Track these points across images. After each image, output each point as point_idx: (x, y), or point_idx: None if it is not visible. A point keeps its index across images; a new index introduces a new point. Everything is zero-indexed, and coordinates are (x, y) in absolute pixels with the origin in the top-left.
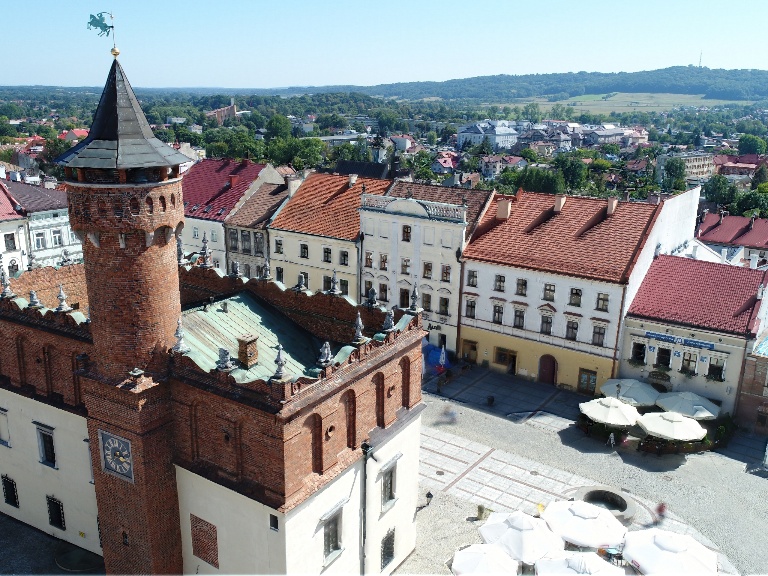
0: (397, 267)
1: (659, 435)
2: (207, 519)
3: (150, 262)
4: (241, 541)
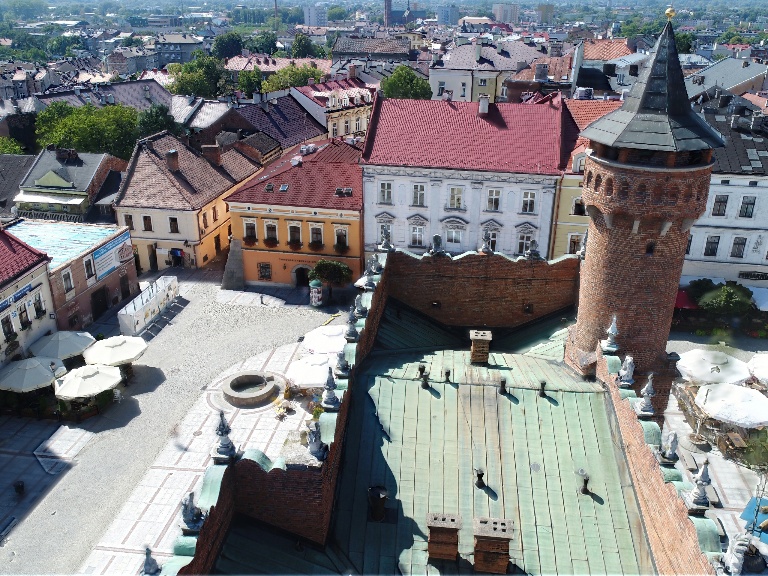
0: None
1: (141, 353)
2: None
3: None
4: None
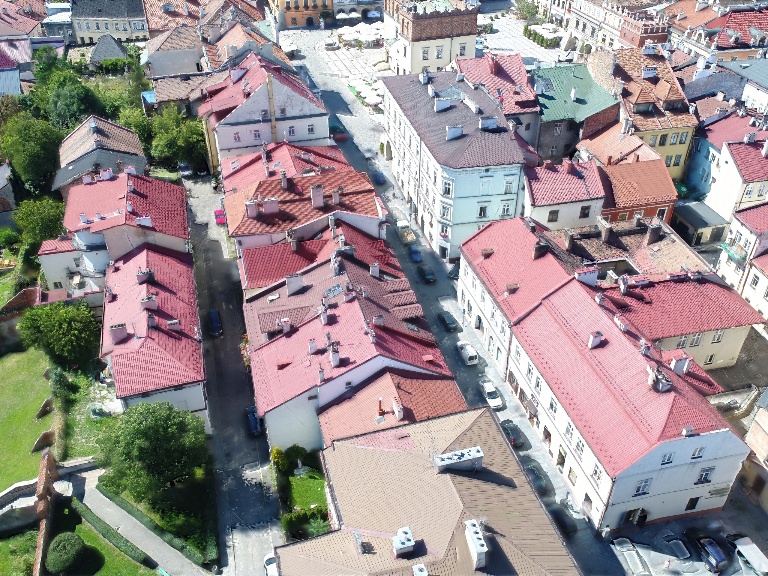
0: None
1: None
2: None
3: None
4: None
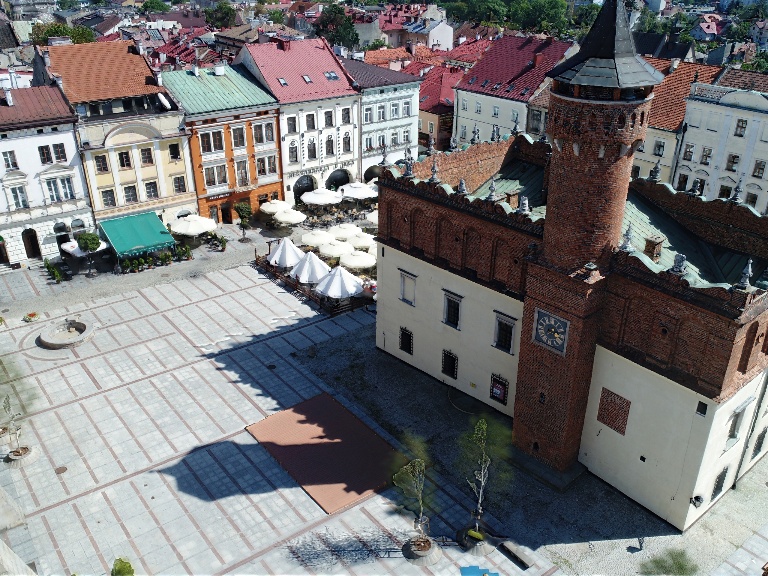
0: (722, 163)
1: None
2: (622, 394)
3: (619, 171)
4: (658, 418)
